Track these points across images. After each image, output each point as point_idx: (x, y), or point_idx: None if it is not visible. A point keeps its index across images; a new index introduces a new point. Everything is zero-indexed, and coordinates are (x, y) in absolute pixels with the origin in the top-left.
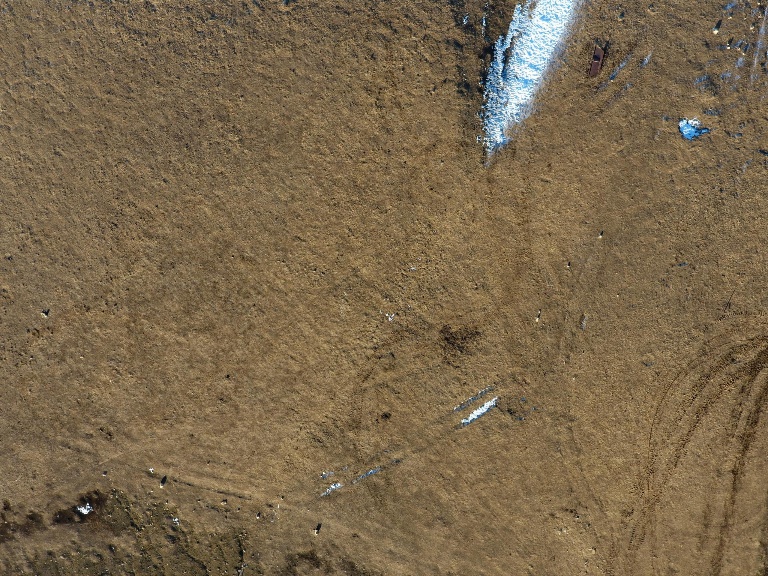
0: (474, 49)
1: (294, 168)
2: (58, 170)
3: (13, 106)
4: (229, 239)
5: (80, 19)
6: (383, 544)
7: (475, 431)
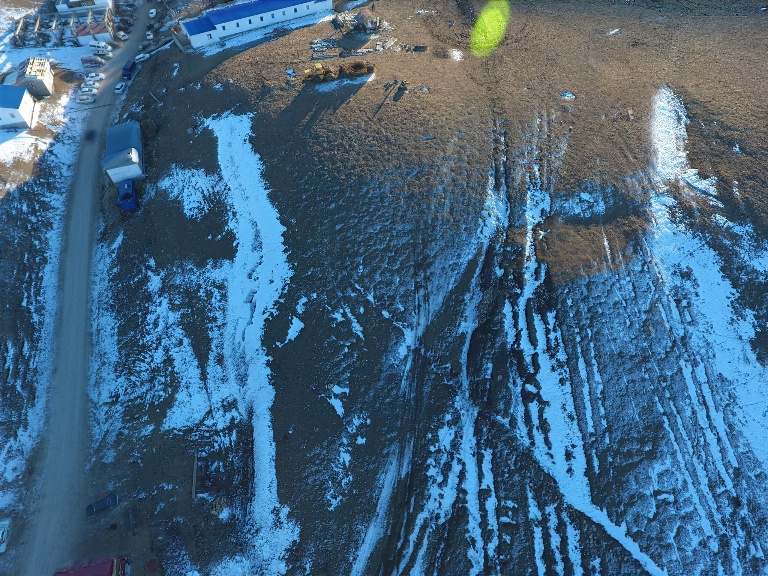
0: (702, 115)
1: (764, 74)
2: None
3: None
4: None
5: None
6: None
7: None
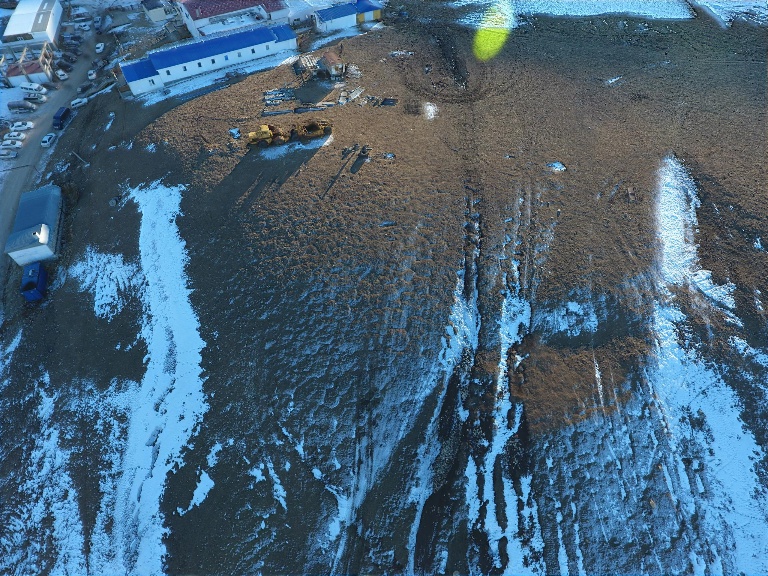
0: (715, 196)
1: None
2: None
3: None
4: None
5: None
6: None
7: None
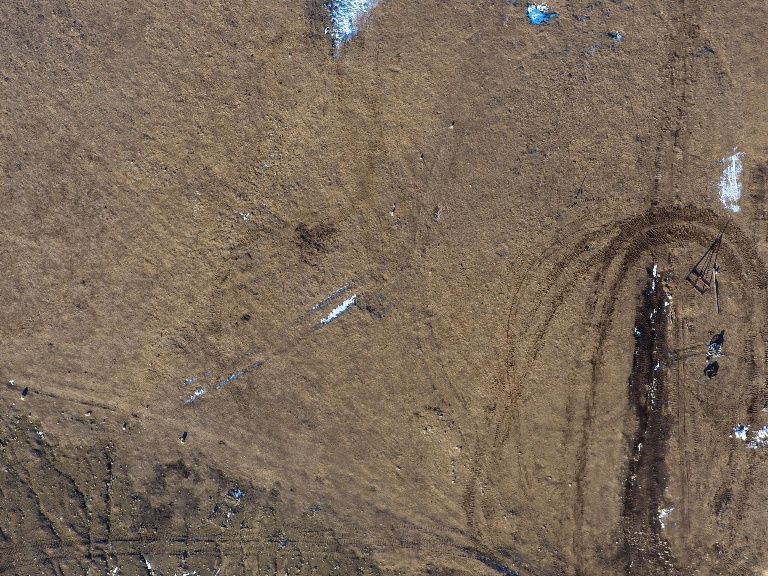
0: None
1: (139, 64)
2: None
3: None
4: (76, 139)
5: None
6: (249, 450)
7: (335, 330)
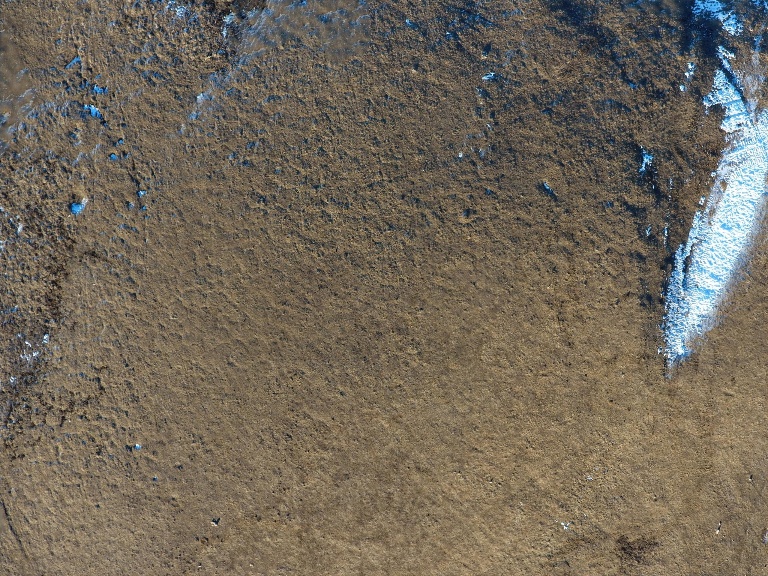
0: (656, 260)
1: (473, 381)
2: (231, 381)
3: (184, 314)
4: (405, 451)
5: (254, 227)
6: None
7: None
